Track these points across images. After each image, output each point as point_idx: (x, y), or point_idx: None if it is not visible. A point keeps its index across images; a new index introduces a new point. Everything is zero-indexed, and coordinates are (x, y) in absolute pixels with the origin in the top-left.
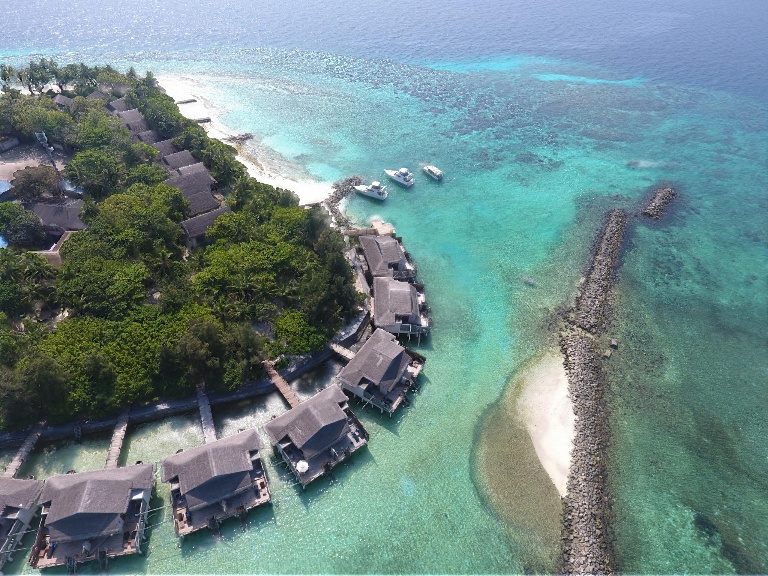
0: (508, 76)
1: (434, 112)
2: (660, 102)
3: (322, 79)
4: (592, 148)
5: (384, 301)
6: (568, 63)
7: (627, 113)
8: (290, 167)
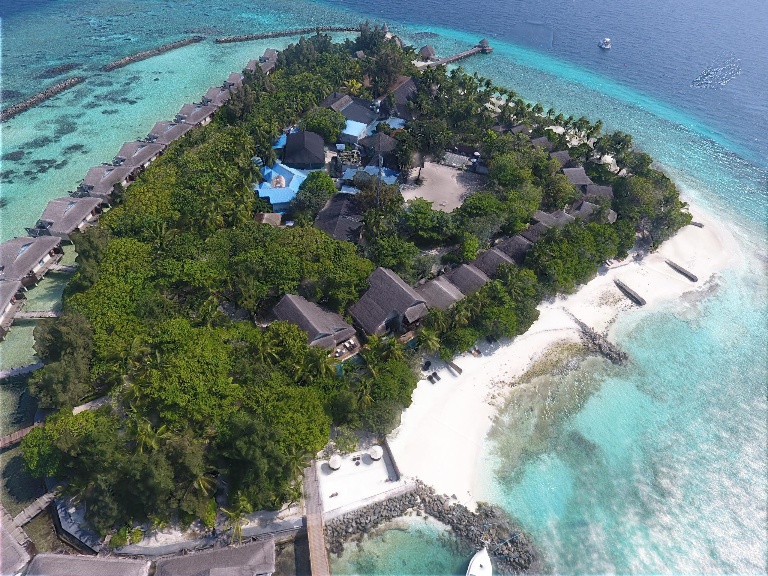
0: None
1: None
2: None
3: None
4: None
5: (73, 572)
6: None
7: None
8: (535, 426)
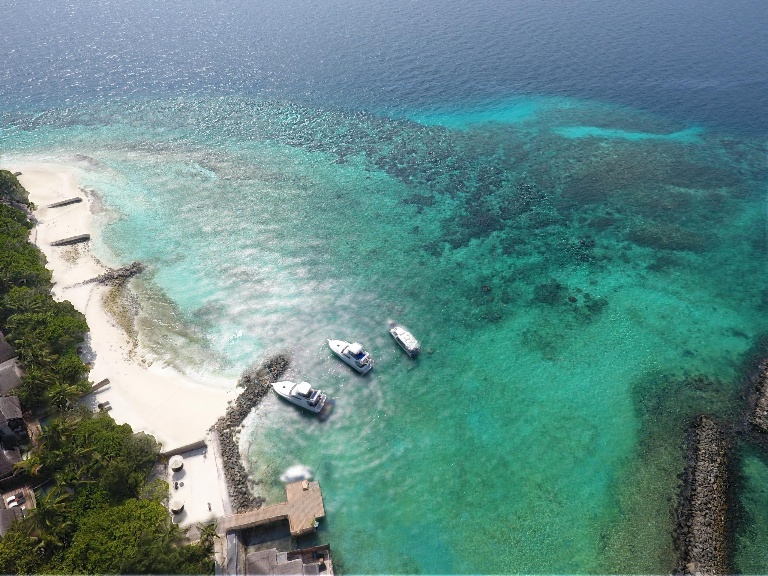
0: (521, 132)
1: (417, 203)
2: (730, 170)
3: (270, 149)
4: (647, 267)
5: None
6: (599, 107)
7: (688, 193)
8: (181, 336)
